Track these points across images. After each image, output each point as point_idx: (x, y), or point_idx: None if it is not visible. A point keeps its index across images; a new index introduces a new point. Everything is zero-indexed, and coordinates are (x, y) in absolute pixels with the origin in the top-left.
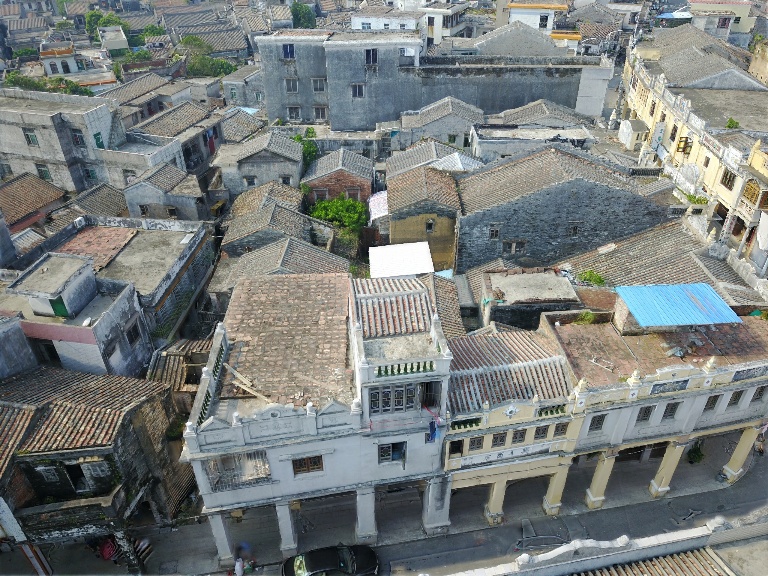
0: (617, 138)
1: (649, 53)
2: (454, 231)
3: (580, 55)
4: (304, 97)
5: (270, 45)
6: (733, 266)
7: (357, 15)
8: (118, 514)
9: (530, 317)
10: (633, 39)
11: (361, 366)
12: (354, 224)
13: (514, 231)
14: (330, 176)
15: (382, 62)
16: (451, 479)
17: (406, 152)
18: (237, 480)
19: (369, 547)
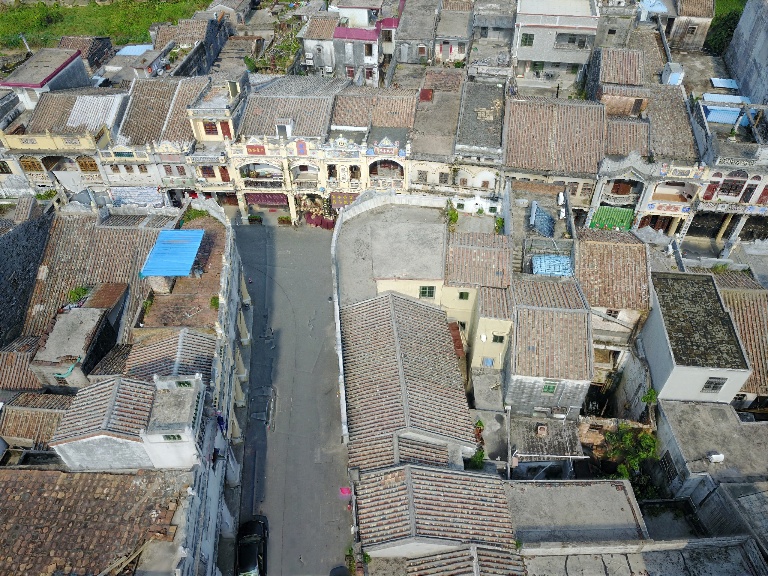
0: None
1: None
2: None
3: None
4: None
5: None
6: (119, 213)
7: None
8: None
9: (99, 348)
10: None
11: (190, 432)
12: None
13: None
14: None
15: None
16: None
17: None
18: None
19: (242, 525)
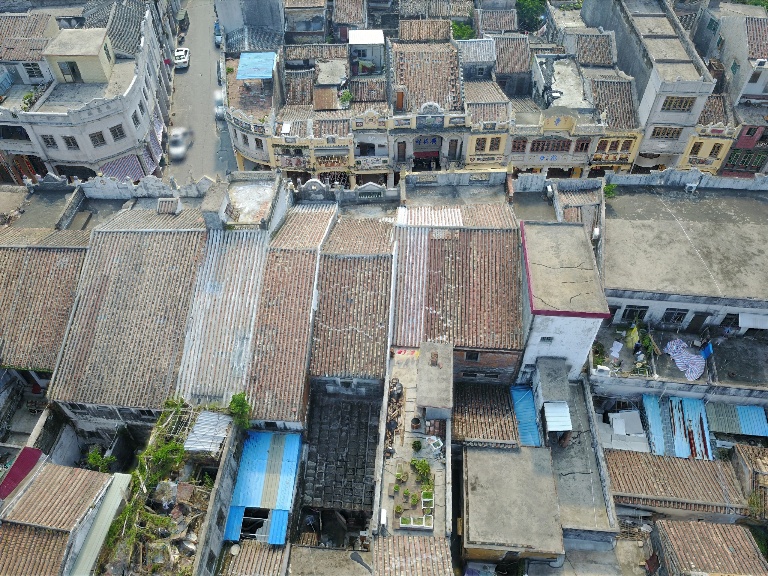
0: None
1: None
2: None
3: None
4: None
5: None
6: None
7: None
8: None
9: None
10: None
11: None
12: None
13: None
14: None
15: None
16: None
17: None
18: None
19: None
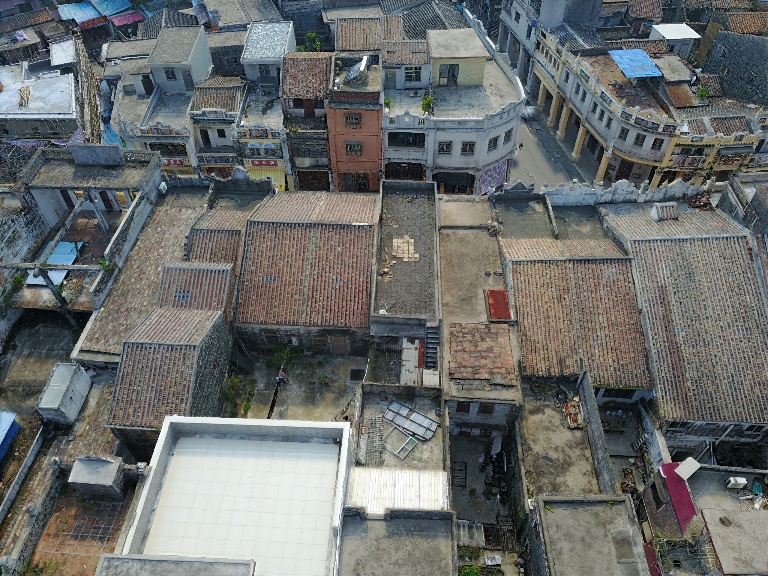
0: None
1: None
2: None
3: None
4: None
5: None
6: None
7: None
8: (492, 0)
9: None
10: None
11: None
12: None
13: (731, 59)
14: None
15: None
16: (534, 63)
17: None
18: (506, 7)
19: None
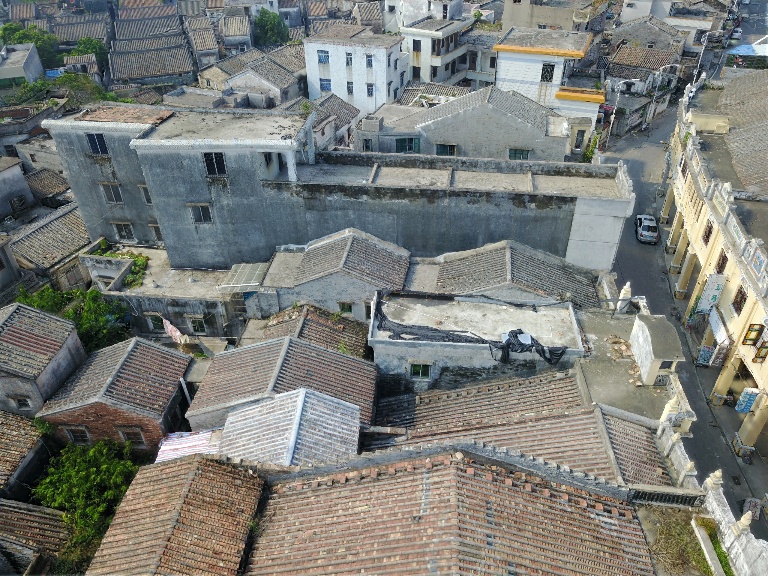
0: (627, 344)
1: (711, 122)
2: None
3: (619, 94)
4: (134, 210)
5: (68, 134)
6: None
7: (311, 40)
8: None
9: None
10: (691, 88)
11: None
12: (93, 528)
13: None
14: (83, 409)
15: (234, 173)
16: None
17: (244, 349)
18: None
19: None
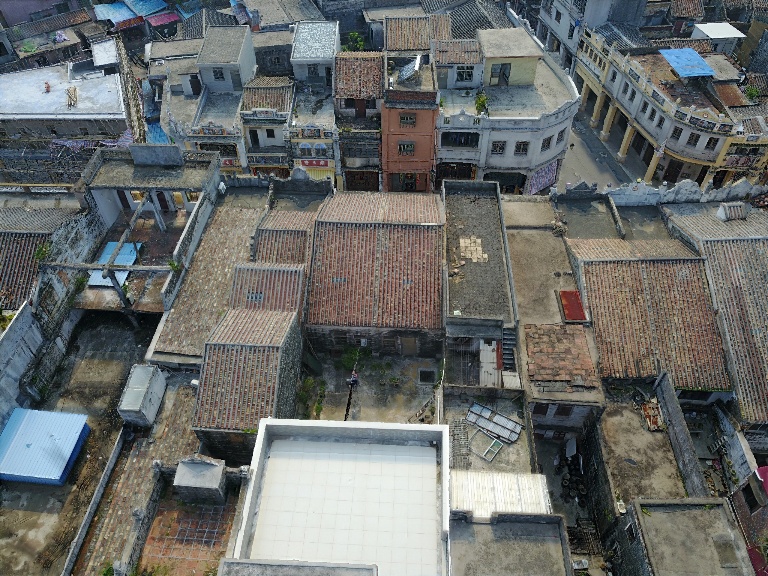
0: None
1: None
2: (760, 39)
3: None
4: None
5: None
6: None
7: None
8: None
9: None
10: None
11: None
12: None
13: None
14: None
15: None
16: (577, 63)
17: None
18: None
19: None
